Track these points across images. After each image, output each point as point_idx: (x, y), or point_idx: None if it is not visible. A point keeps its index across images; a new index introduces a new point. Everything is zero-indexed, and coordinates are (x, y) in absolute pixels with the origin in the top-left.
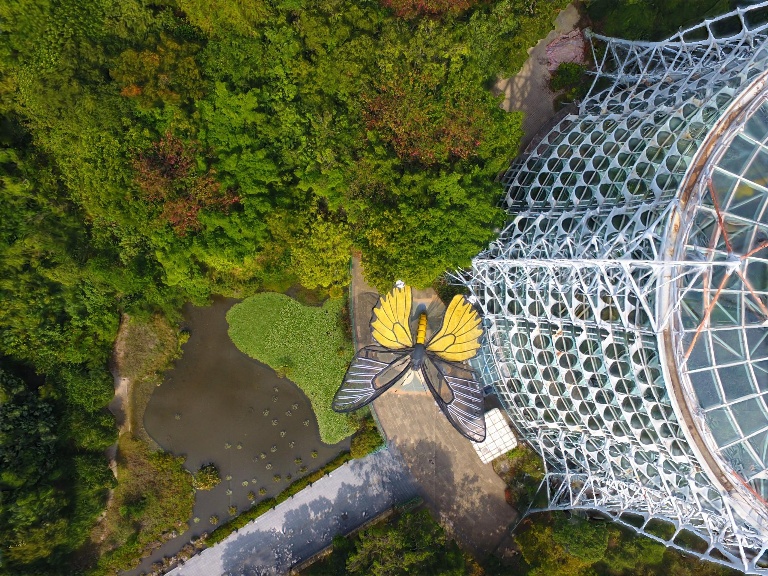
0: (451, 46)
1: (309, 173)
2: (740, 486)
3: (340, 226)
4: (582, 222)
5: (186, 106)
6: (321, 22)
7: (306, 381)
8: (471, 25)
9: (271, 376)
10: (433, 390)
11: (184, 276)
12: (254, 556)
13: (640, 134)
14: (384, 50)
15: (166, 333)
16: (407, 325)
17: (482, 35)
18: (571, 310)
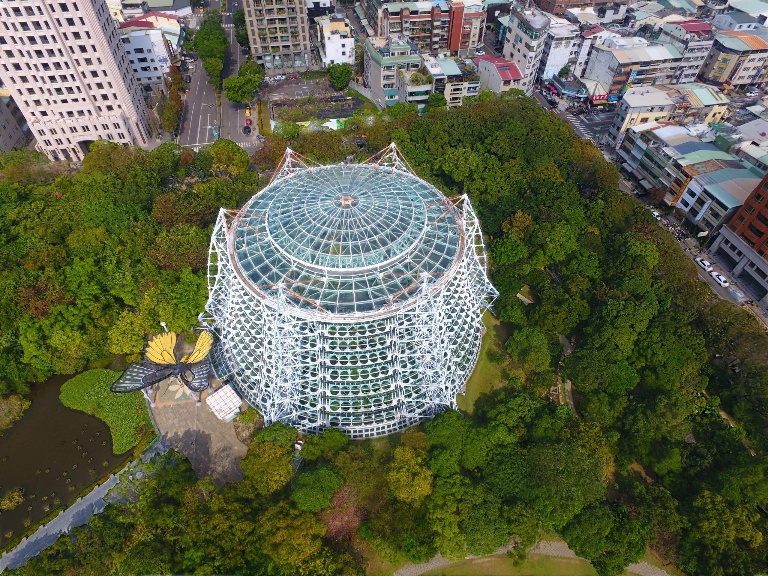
0: None
1: None
2: (266, 294)
3: (137, 314)
4: None
5: (57, 269)
6: None
7: (109, 416)
8: (208, 228)
9: (84, 418)
10: (184, 380)
11: (34, 348)
12: None
13: None
14: (159, 235)
15: (15, 405)
16: (172, 353)
17: None
18: (230, 290)
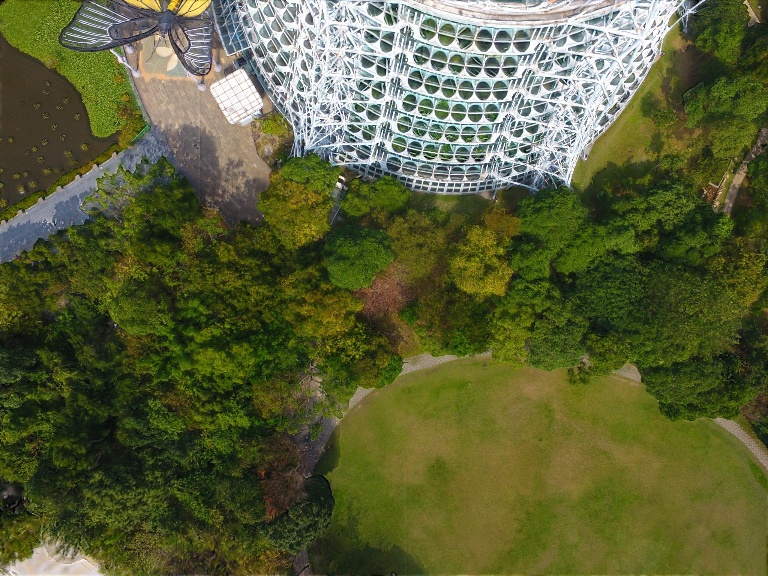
0: None
1: None
2: None
3: None
4: None
5: None
6: None
7: (77, 75)
8: None
9: (42, 70)
10: (175, 46)
11: None
12: (25, 247)
13: None
14: None
15: None
16: None
17: None
18: None
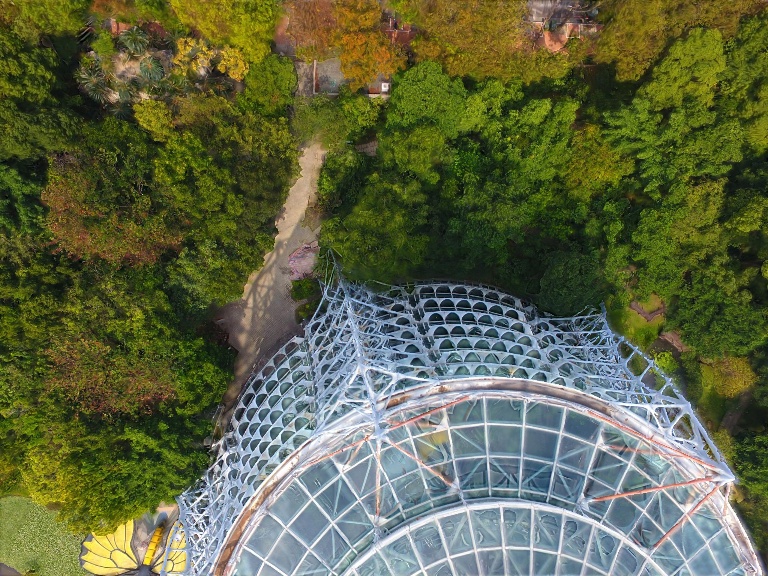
0: (132, 305)
1: (8, 417)
2: None
3: (60, 452)
4: (223, 512)
5: None
6: (3, 280)
7: None
8: (178, 264)
9: None
10: None
11: None
12: None
13: (282, 424)
14: (66, 308)
15: None
16: (129, 549)
17: (191, 272)
18: None
